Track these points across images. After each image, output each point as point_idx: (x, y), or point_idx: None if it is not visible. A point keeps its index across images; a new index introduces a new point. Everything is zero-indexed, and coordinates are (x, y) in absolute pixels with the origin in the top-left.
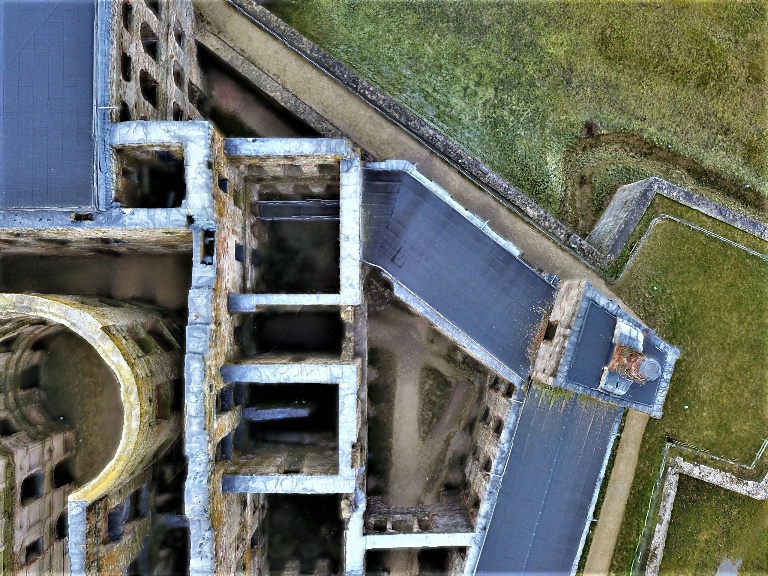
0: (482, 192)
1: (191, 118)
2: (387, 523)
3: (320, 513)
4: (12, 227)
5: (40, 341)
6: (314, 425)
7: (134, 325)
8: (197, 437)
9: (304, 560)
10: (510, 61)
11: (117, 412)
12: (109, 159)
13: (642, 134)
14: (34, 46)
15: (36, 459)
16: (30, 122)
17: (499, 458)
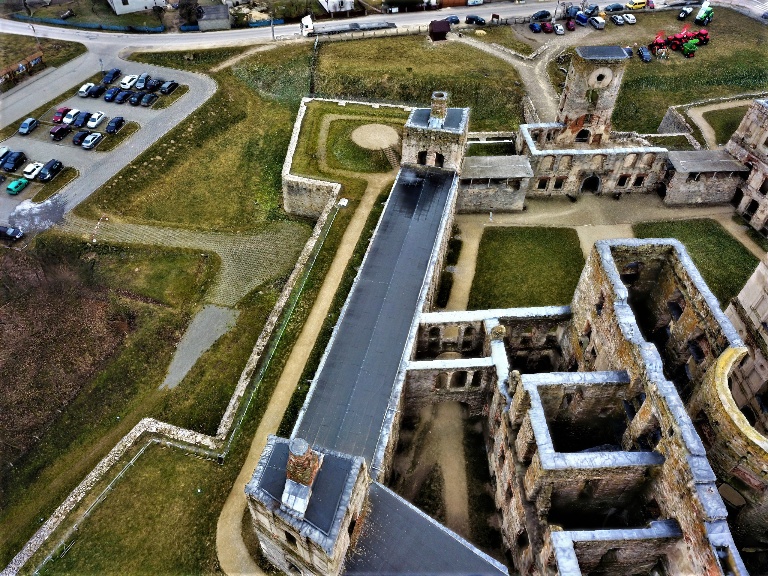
0: None
1: None
2: None
3: None
4: None
5: None
6: None
7: (759, 501)
8: (668, 392)
9: (524, 369)
10: None
11: None
12: None
13: None
14: None
15: None
16: None
17: (390, 423)
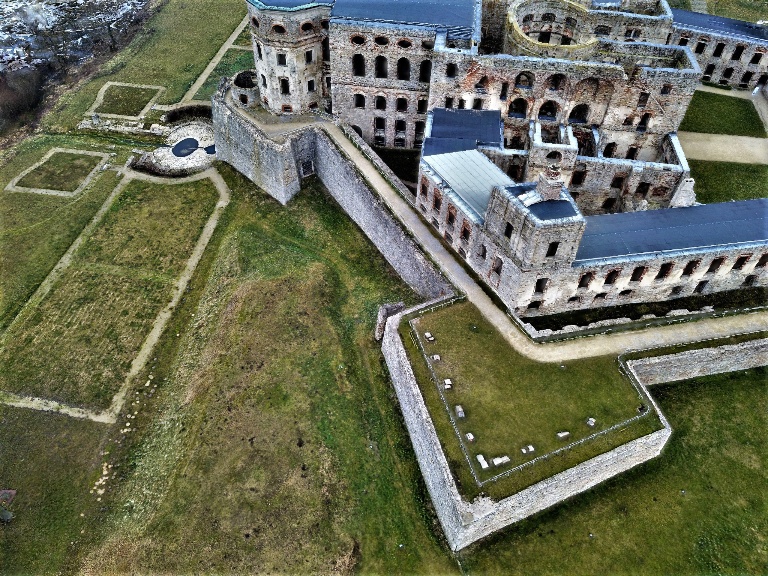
0: None
1: None
2: None
3: None
4: (481, 12)
5: None
6: None
7: None
8: None
9: None
10: None
11: None
12: None
13: None
14: None
15: None
16: None
17: None
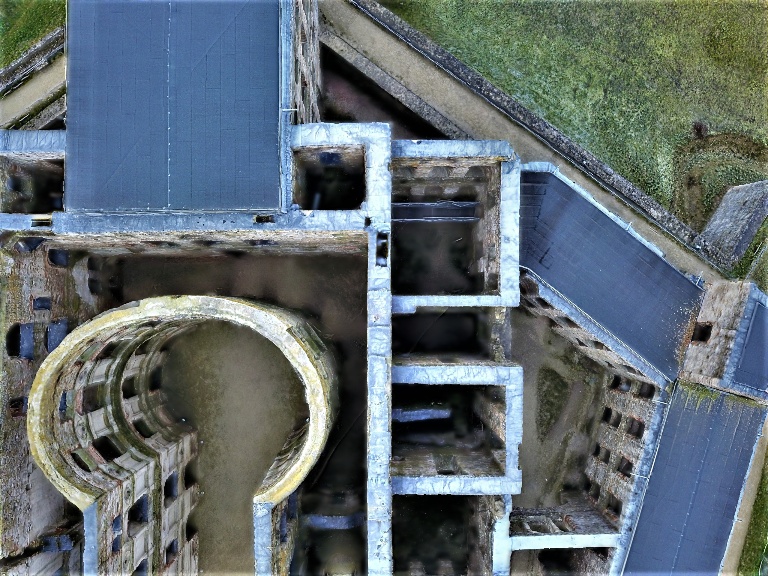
0: (605, 193)
1: (317, 120)
2: (524, 524)
3: (438, 514)
4: (195, 229)
5: (166, 343)
6: (451, 426)
7: (297, 327)
8: (381, 439)
9: (426, 561)
10: (619, 62)
11: (238, 414)
12: (289, 161)
13: (751, 135)
14: (221, 48)
15: (172, 461)
16: (217, 124)
17: (644, 459)
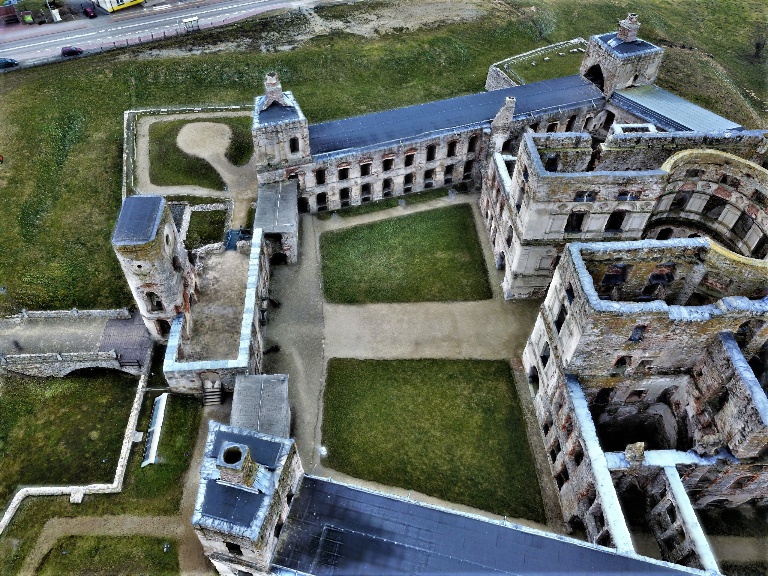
0: None
1: None
2: None
3: None
4: None
5: None
6: None
7: None
8: None
9: None
10: None
11: None
12: None
13: None
14: None
15: None
16: None
17: None
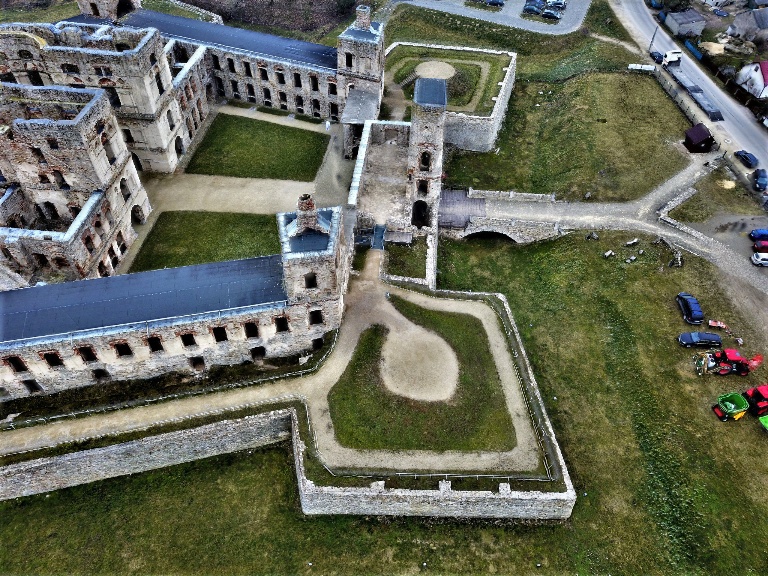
0: None
1: None
2: None
3: None
4: None
5: None
6: None
7: None
8: None
9: None
10: None
11: None
12: None
13: None
14: None
15: None
16: None
17: None
